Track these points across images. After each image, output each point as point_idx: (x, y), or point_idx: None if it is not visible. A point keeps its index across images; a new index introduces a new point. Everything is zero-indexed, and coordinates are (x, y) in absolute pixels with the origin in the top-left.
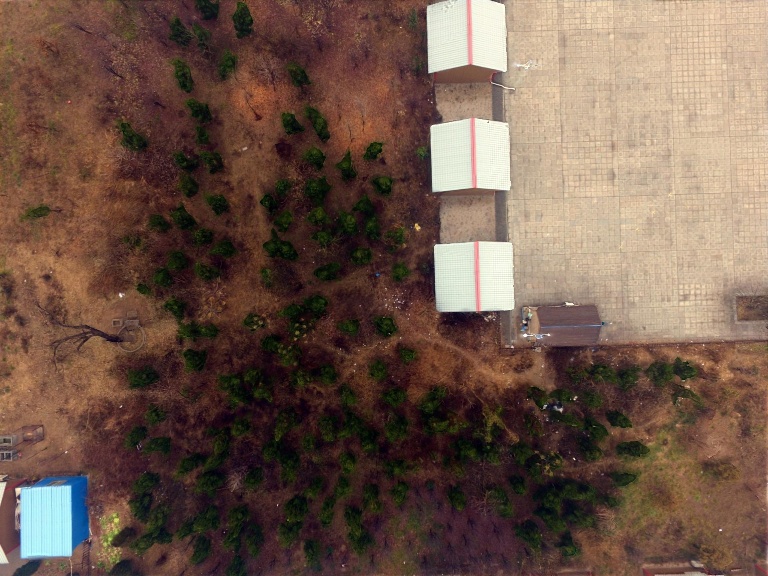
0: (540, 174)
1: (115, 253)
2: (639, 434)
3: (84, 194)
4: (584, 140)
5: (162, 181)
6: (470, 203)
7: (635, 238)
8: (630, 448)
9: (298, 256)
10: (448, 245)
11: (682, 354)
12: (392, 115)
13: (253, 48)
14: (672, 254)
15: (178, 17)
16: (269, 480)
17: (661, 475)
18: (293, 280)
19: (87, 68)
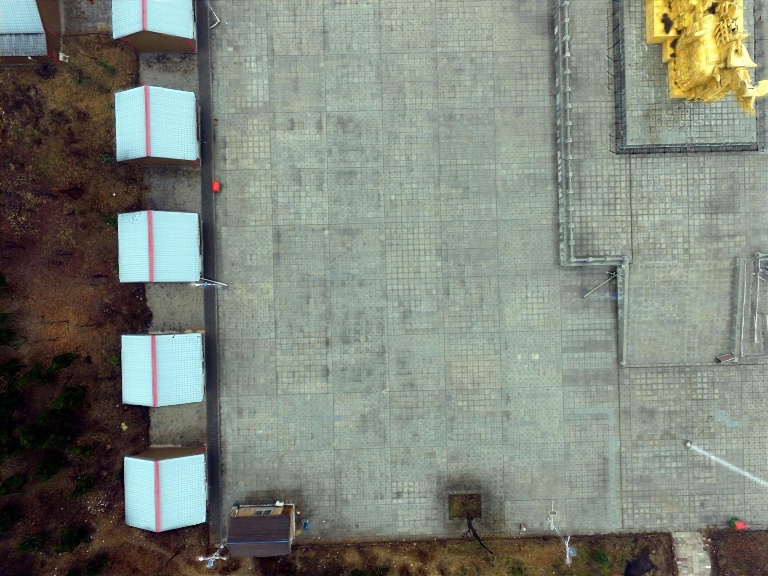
0: (253, 370)
1: None
2: None
3: None
4: (298, 336)
5: None
6: None
7: (349, 435)
8: None
9: None
10: (134, 460)
11: (391, 555)
12: (97, 314)
13: None
14: (386, 451)
15: None
16: None
17: None
18: None
19: None
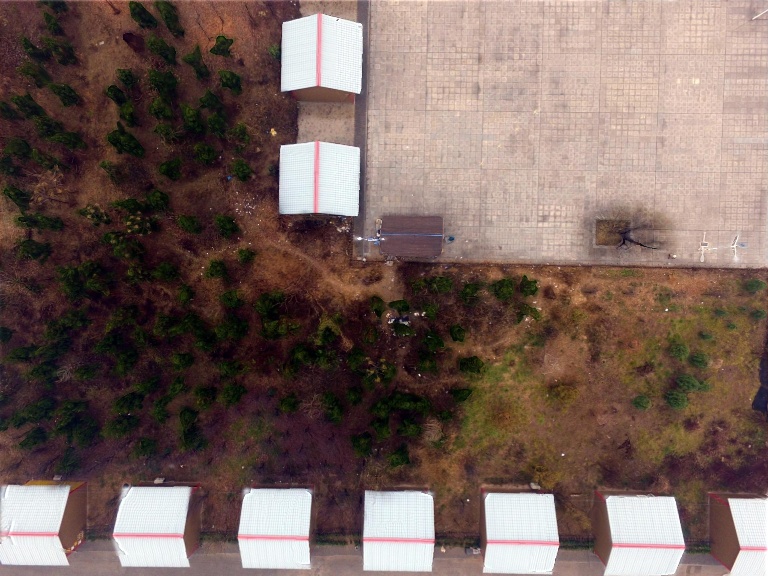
0: (403, 84)
1: None
2: (486, 354)
3: None
4: (450, 51)
5: (17, 72)
6: (329, 111)
7: (497, 155)
8: (467, 362)
9: (151, 155)
10: (292, 146)
11: (535, 275)
12: (252, 15)
13: None
14: (534, 173)
15: None
16: (111, 377)
17: (506, 396)
18: (144, 179)
19: None
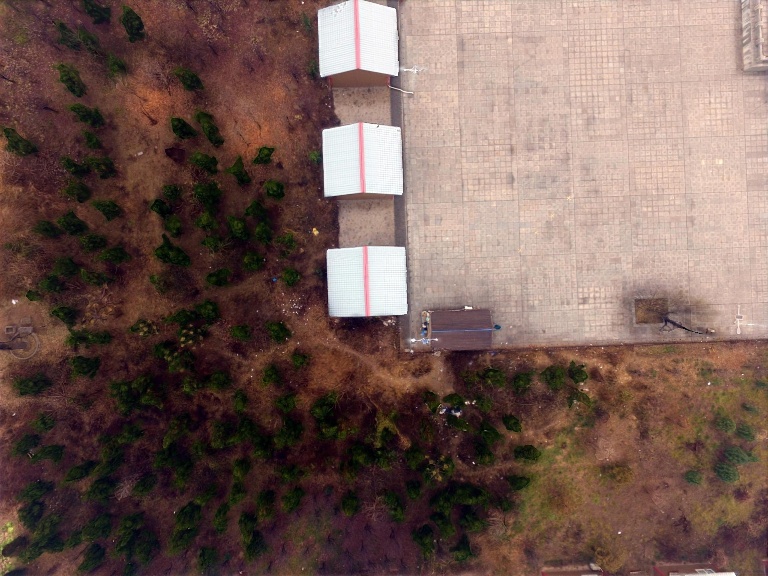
0: (439, 178)
1: (7, 259)
2: (538, 437)
3: None
4: (483, 144)
5: (56, 186)
6: (369, 207)
7: (534, 242)
8: (523, 452)
9: (194, 261)
10: (339, 250)
11: (580, 357)
12: (289, 119)
13: (148, 52)
14: (571, 257)
15: None
16: (165, 487)
17: (560, 478)
18: (189, 286)
19: None
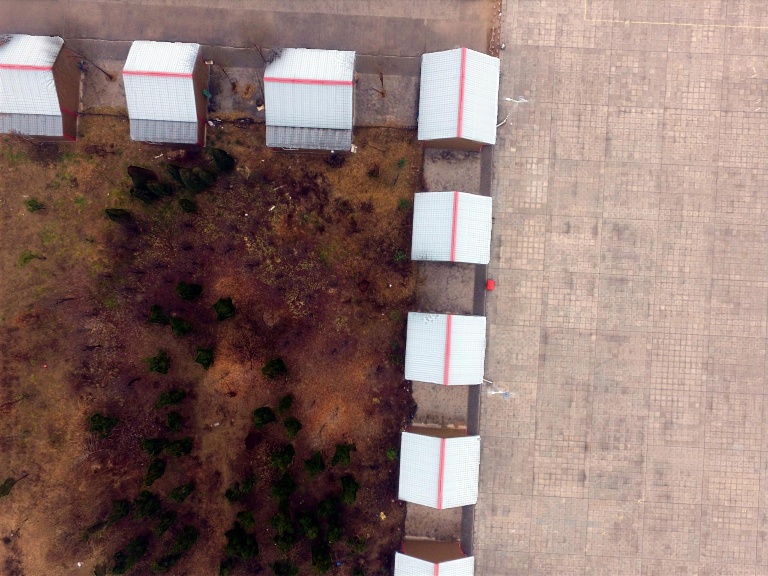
0: (511, 469)
1: (77, 523)
2: None
3: (52, 459)
4: (558, 439)
5: (131, 451)
6: None
7: (601, 542)
8: None
9: (260, 537)
10: (409, 557)
11: None
12: (367, 403)
13: (233, 324)
14: (637, 561)
15: (161, 288)
16: None
17: None
18: (253, 562)
19: (66, 333)
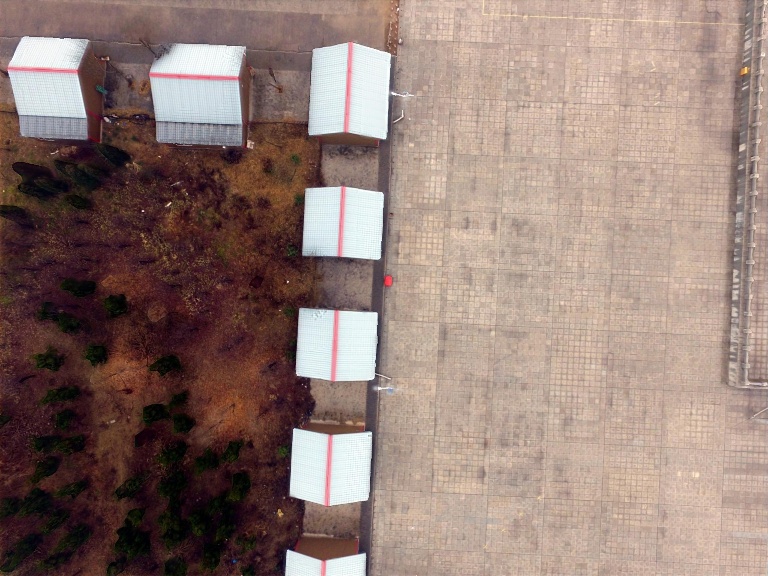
0: (410, 466)
1: None
2: None
3: None
4: (457, 435)
5: (26, 449)
6: None
7: (500, 539)
8: None
9: (157, 535)
10: (299, 554)
11: None
12: (263, 399)
13: (129, 321)
14: (537, 558)
15: (57, 285)
16: None
17: None
18: (149, 560)
19: None
